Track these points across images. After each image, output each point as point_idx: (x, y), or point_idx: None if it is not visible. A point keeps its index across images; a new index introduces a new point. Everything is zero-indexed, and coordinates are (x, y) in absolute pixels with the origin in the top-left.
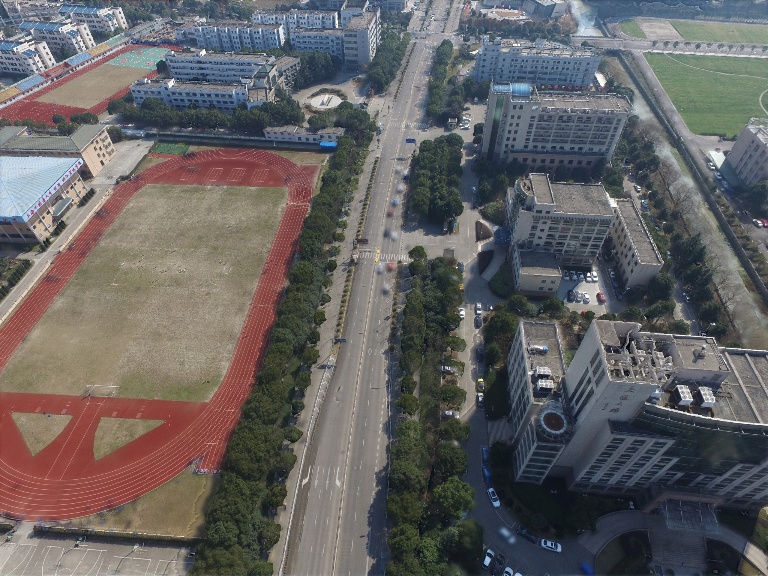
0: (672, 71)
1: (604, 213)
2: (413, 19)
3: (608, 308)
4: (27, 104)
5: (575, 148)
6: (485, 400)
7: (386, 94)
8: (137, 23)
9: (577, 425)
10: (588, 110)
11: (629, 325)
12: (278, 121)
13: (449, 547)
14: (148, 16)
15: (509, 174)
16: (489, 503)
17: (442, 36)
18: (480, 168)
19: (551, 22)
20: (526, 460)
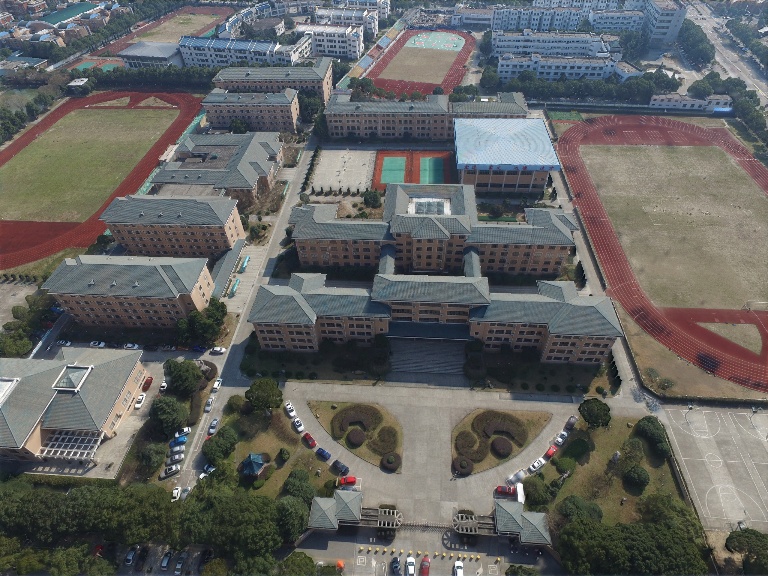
0: None
1: None
2: None
3: None
4: (376, 81)
5: None
6: None
7: (712, 68)
8: None
9: None
10: None
11: None
12: (662, 89)
13: None
14: (410, 4)
15: None
16: None
17: None
18: None
19: None
20: None
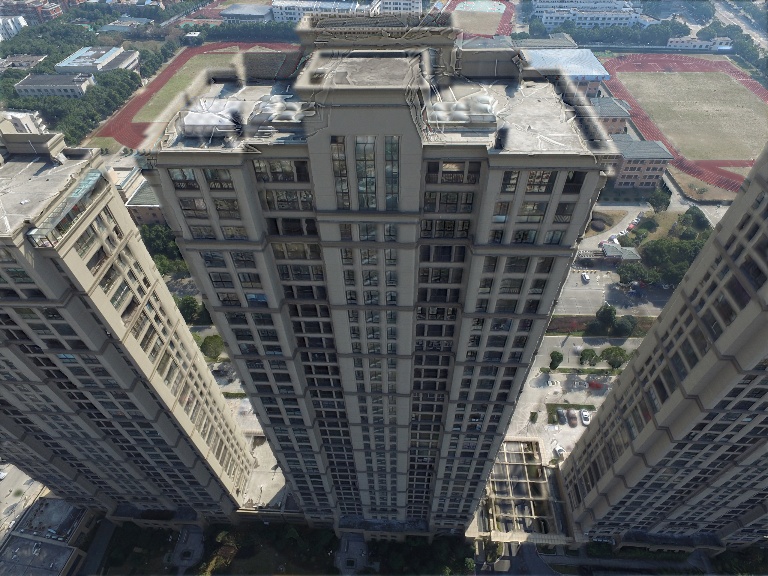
0: None
1: None
2: None
3: None
4: None
5: None
6: None
7: None
8: None
9: None
10: None
11: None
12: (676, 34)
13: None
14: None
15: None
16: None
17: None
18: None
19: None
20: None
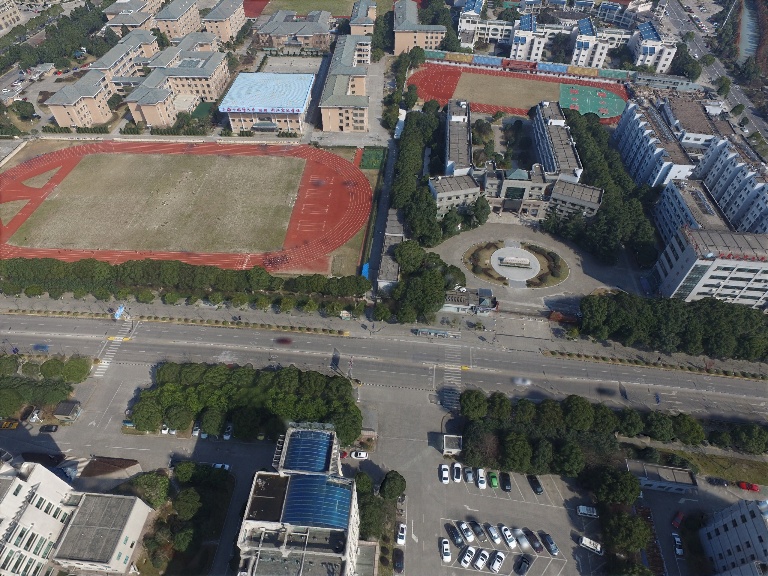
0: None
1: None
2: None
3: None
4: (454, 72)
5: None
6: None
7: (569, 339)
8: (683, 74)
9: None
10: None
11: None
12: None
13: None
14: (691, 72)
15: None
16: None
17: None
18: None
19: None
20: None
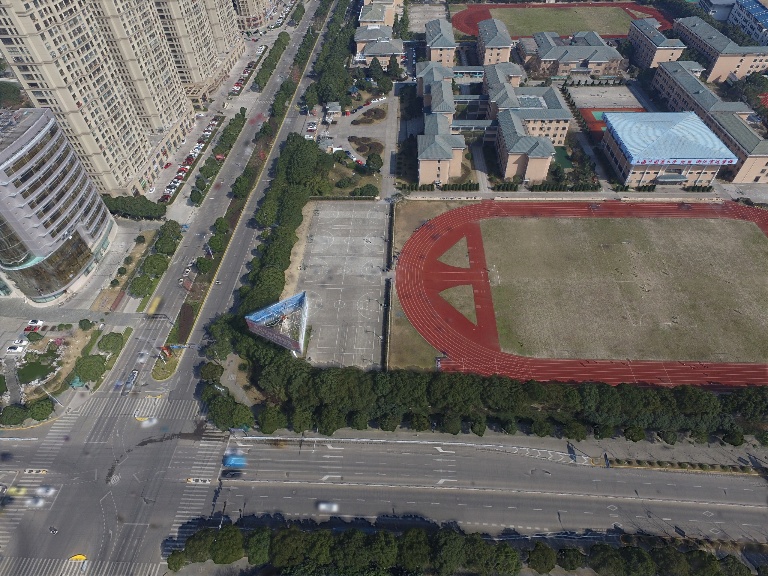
0: None
1: None
2: None
3: None
4: None
5: None
6: None
7: None
8: None
9: None
10: None
11: None
12: None
13: None
14: None
15: None
16: None
17: None
18: None
19: None
20: None
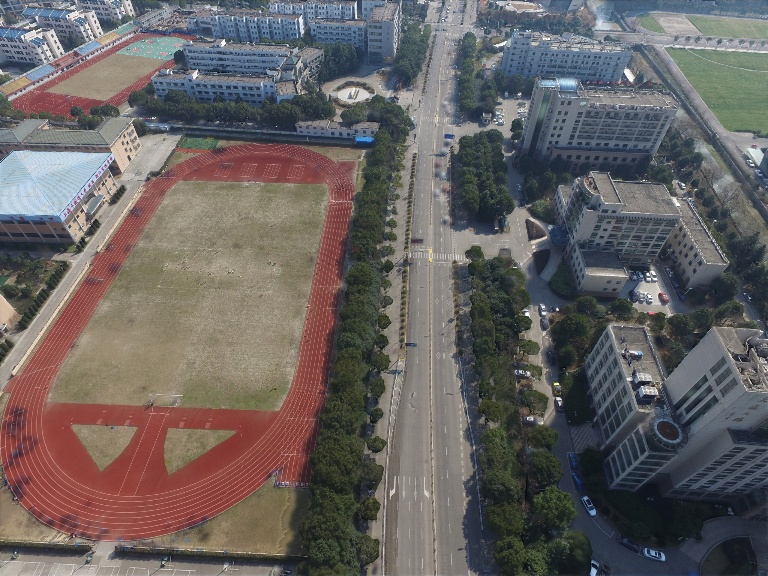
0: (696, 67)
1: (670, 212)
2: (429, 10)
3: (672, 308)
4: (39, 95)
5: (620, 145)
6: (565, 405)
7: (414, 88)
8: (144, 11)
9: (690, 433)
10: (637, 106)
11: (750, 332)
12: (310, 115)
13: (558, 560)
14: (156, 4)
15: (553, 171)
16: (585, 512)
17: (461, 28)
18: (524, 165)
19: (569, 15)
20: (630, 469)
